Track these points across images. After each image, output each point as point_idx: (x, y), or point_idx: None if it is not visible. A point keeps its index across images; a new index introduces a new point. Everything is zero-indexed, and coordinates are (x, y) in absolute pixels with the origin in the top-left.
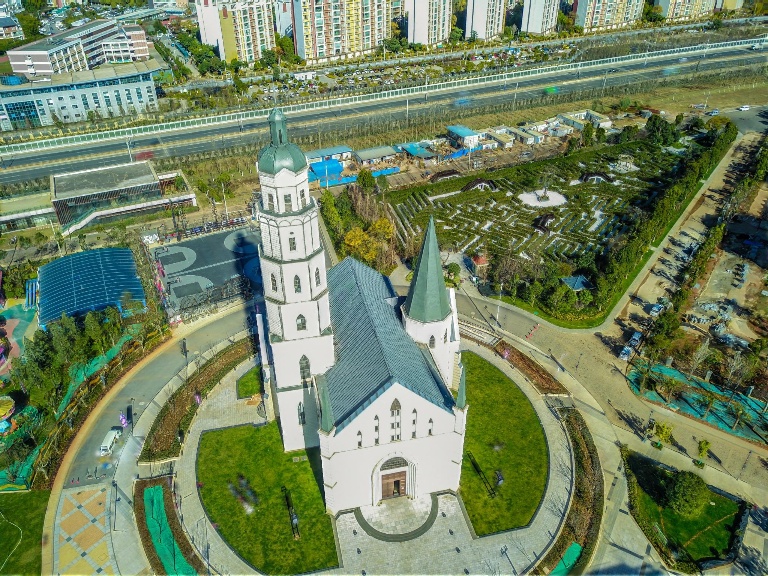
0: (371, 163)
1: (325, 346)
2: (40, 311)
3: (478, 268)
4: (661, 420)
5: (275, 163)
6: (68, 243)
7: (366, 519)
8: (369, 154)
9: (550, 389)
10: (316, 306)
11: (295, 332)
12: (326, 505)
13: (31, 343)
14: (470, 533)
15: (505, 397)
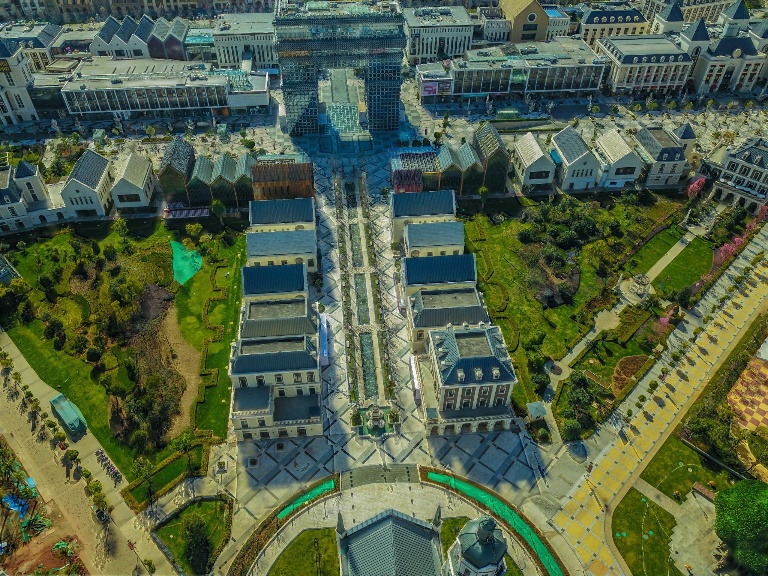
0: None
1: None
2: None
3: None
4: None
5: None
6: None
7: None
8: None
9: None
10: None
11: None
12: None
13: None
14: None
15: None
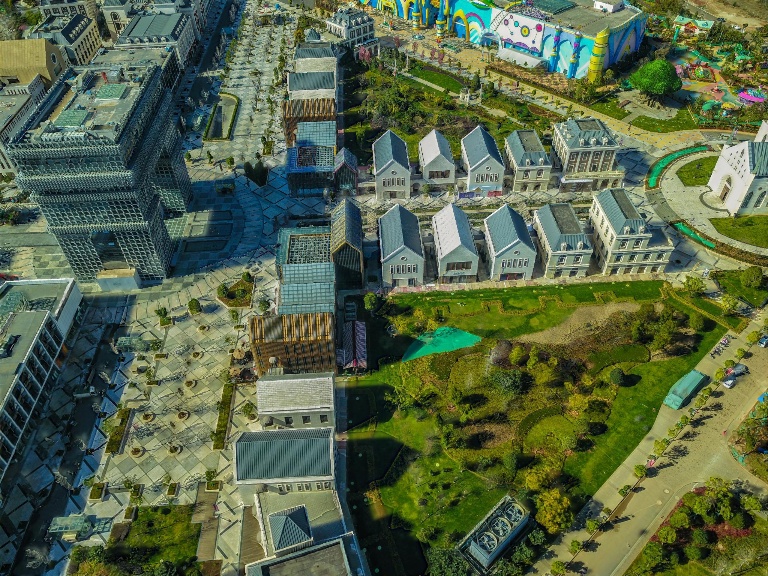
0: None
1: None
2: None
3: None
4: None
5: None
6: None
7: (708, 192)
8: None
9: None
10: None
11: None
12: None
13: (766, 100)
14: None
15: None
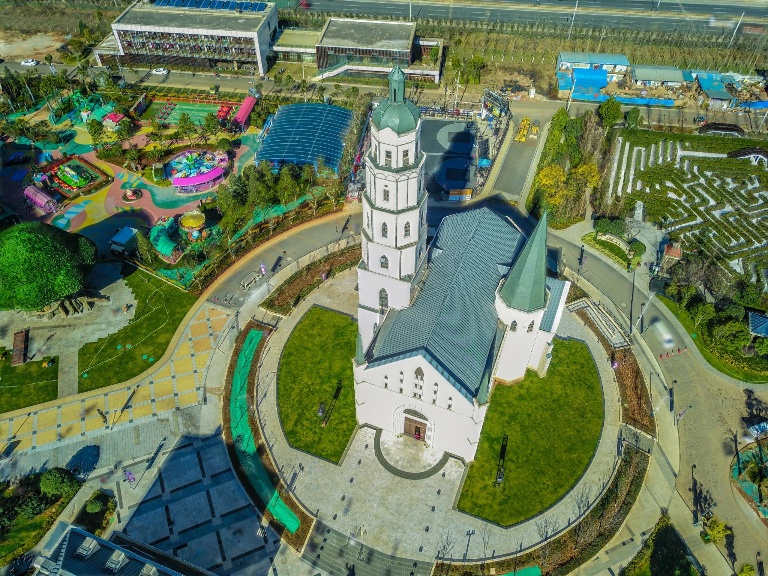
0: (647, 85)
1: (403, 289)
2: (261, 148)
3: (666, 258)
4: (736, 517)
5: (382, 120)
6: (318, 87)
7: (381, 441)
8: (649, 74)
9: (636, 422)
10: (399, 254)
11: (378, 267)
12: (356, 414)
13: (234, 177)
14: (453, 502)
15: (582, 405)
